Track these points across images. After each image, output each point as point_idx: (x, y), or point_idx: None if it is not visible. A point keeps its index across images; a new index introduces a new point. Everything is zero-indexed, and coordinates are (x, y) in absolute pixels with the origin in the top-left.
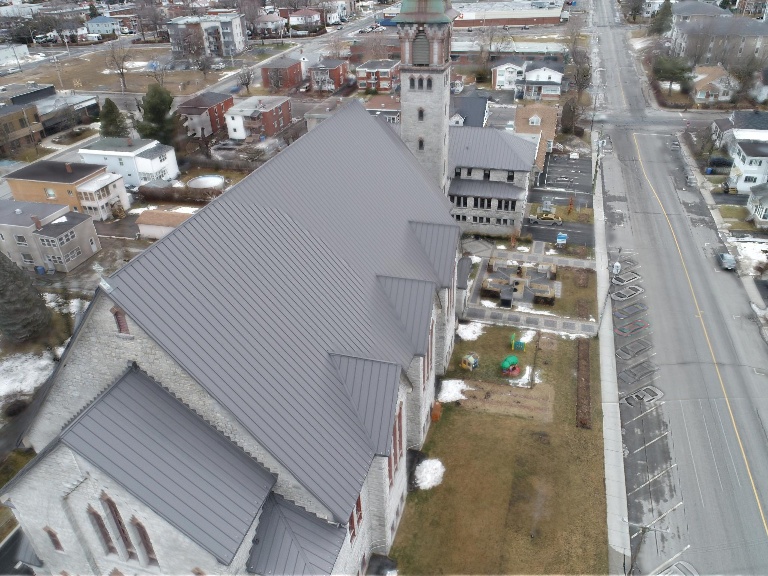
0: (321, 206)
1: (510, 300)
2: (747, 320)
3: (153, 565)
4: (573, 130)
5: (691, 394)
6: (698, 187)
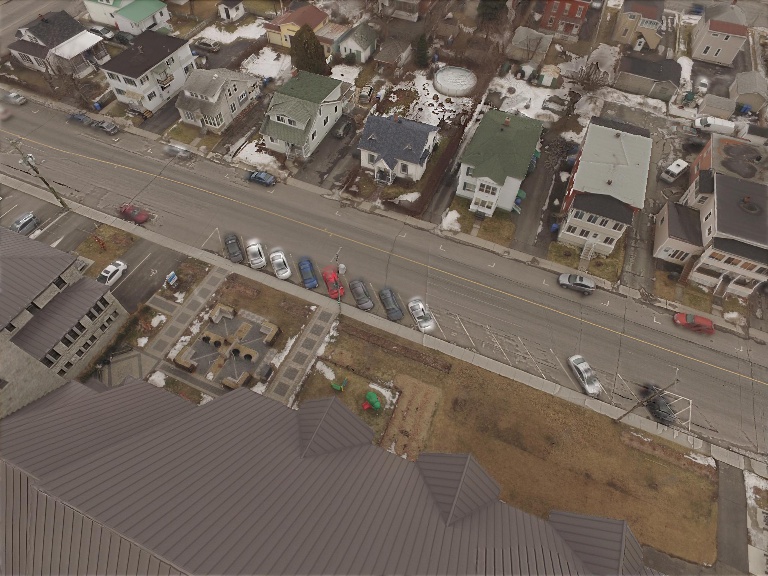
0: None
1: (270, 368)
2: (343, 209)
3: None
4: None
5: (422, 284)
6: (119, 129)
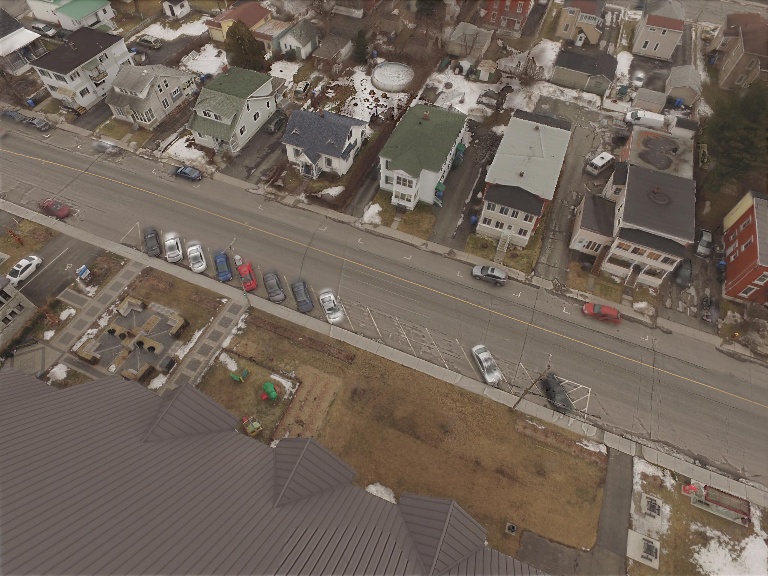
0: (199, 575)
1: (171, 360)
2: (267, 204)
3: None
4: None
5: (335, 276)
6: (51, 126)
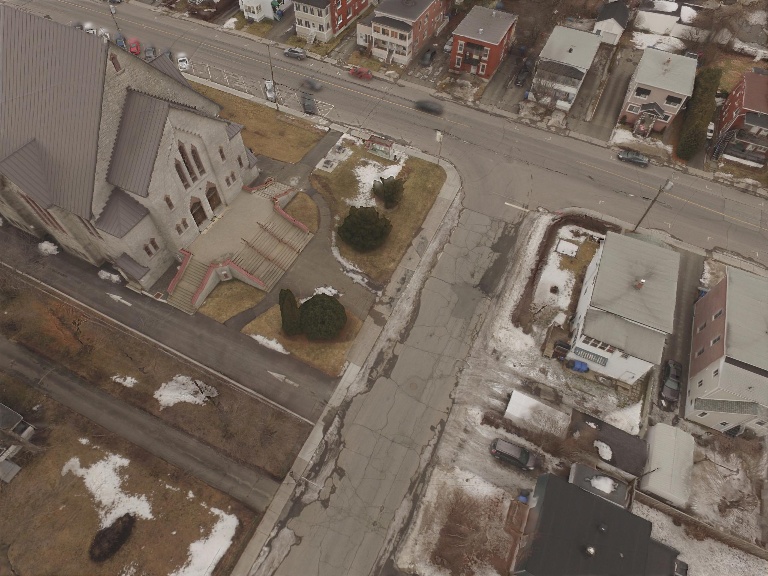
0: None
1: None
2: (161, 16)
3: (202, 176)
4: None
5: (192, 51)
6: None
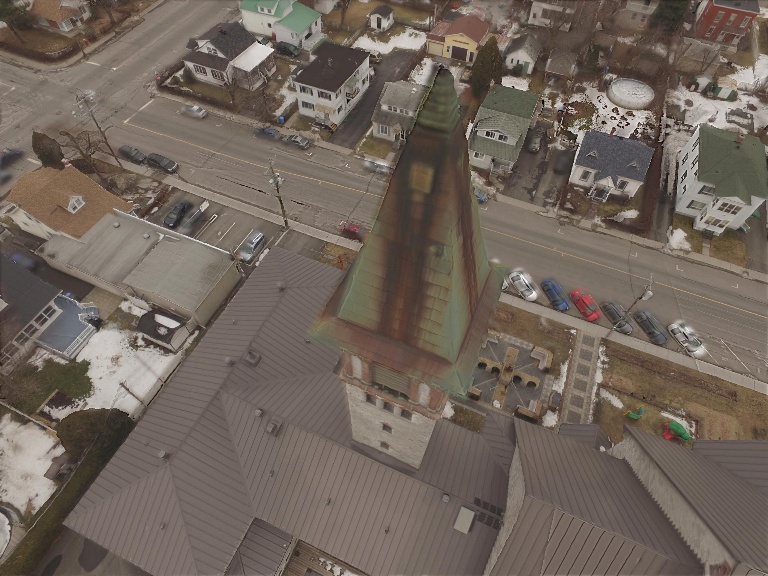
0: None
1: None
2: (564, 228)
3: None
4: (97, 172)
5: (673, 306)
6: None
